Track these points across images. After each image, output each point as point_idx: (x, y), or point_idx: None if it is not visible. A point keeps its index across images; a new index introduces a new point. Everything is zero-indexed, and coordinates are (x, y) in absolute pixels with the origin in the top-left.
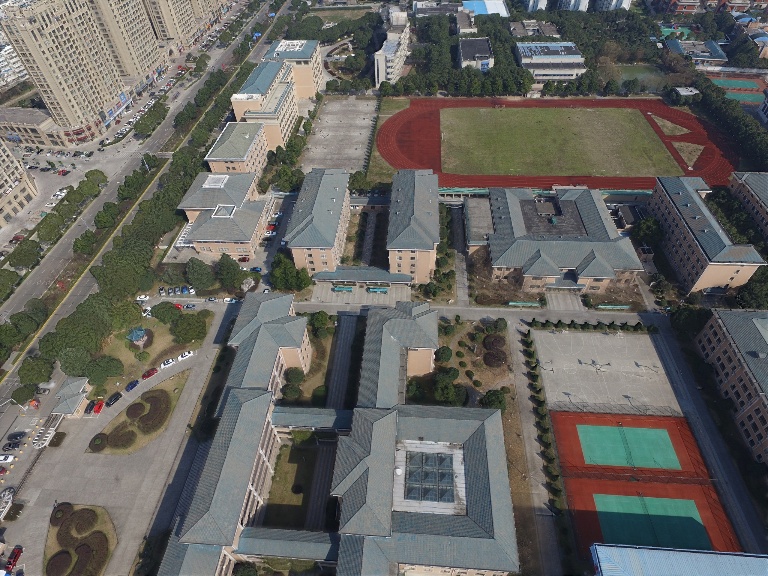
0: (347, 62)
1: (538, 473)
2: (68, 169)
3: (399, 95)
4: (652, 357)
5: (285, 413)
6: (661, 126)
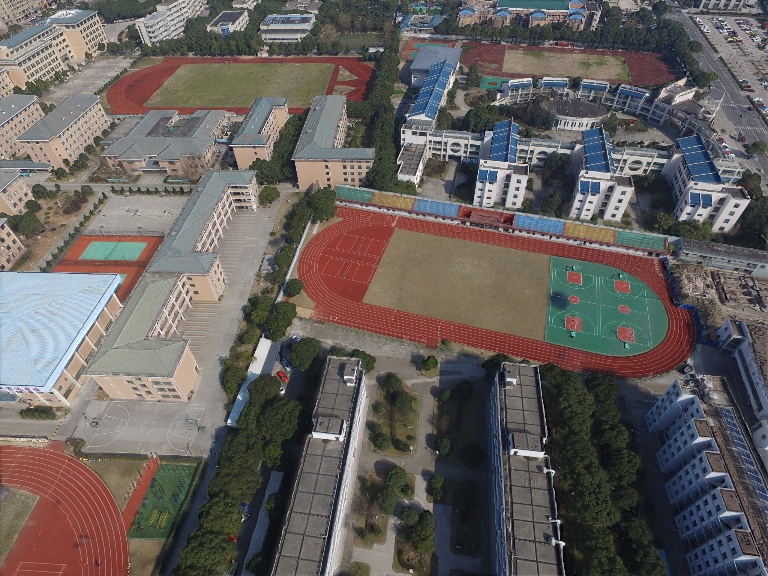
0: (129, 30)
1: (43, 264)
2: None
3: (158, 55)
4: (179, 208)
5: None
6: (339, 75)
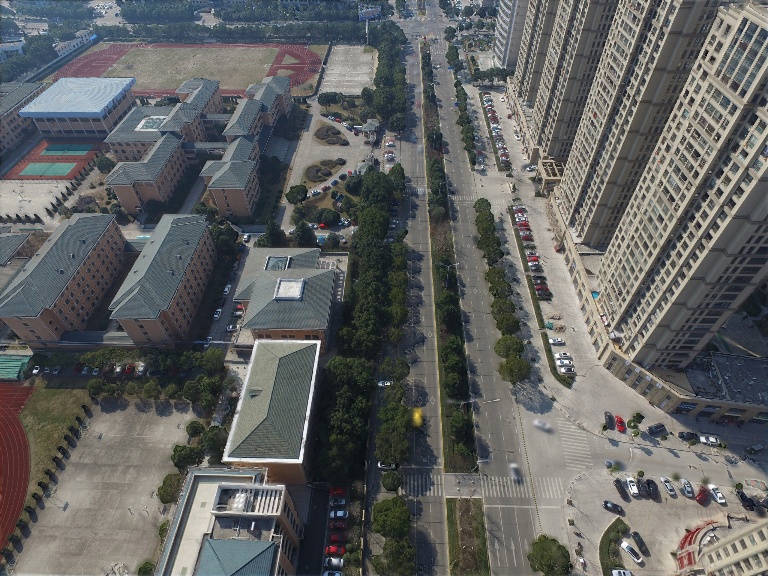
0: None
1: None
2: (620, 436)
3: None
4: None
5: (222, 143)
6: None
